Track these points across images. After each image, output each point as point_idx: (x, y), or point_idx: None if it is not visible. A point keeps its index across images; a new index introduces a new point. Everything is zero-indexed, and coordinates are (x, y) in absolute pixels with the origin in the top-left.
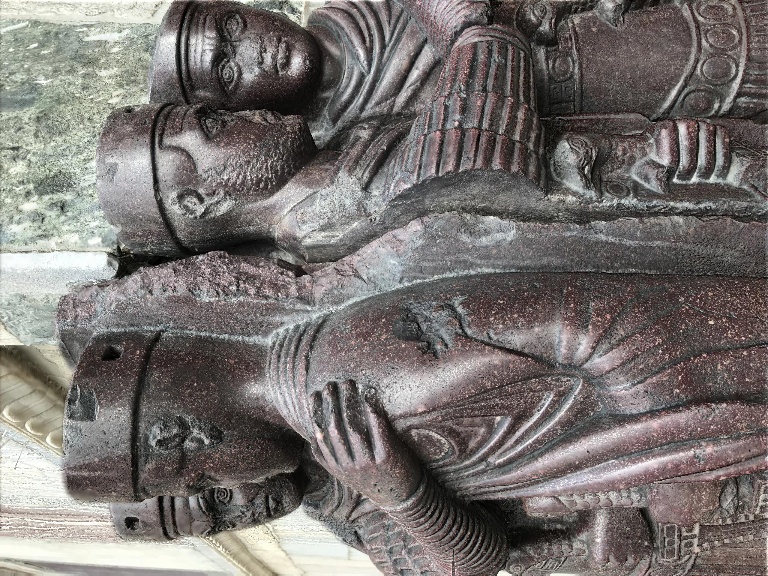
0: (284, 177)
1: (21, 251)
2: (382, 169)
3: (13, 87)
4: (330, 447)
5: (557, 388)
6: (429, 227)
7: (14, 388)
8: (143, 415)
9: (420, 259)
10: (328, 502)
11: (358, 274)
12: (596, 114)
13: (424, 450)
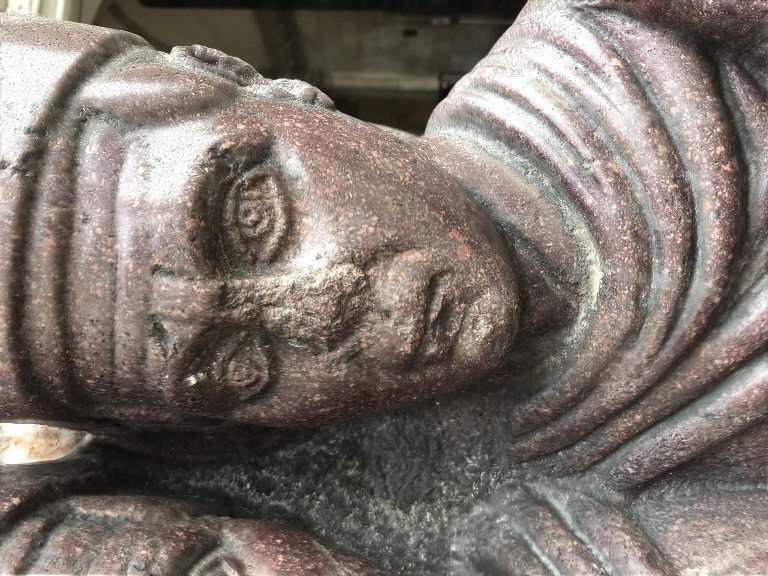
0: None
1: None
2: None
3: None
4: None
5: None
6: None
7: None
8: None
9: None
10: None
11: None
12: None
13: None
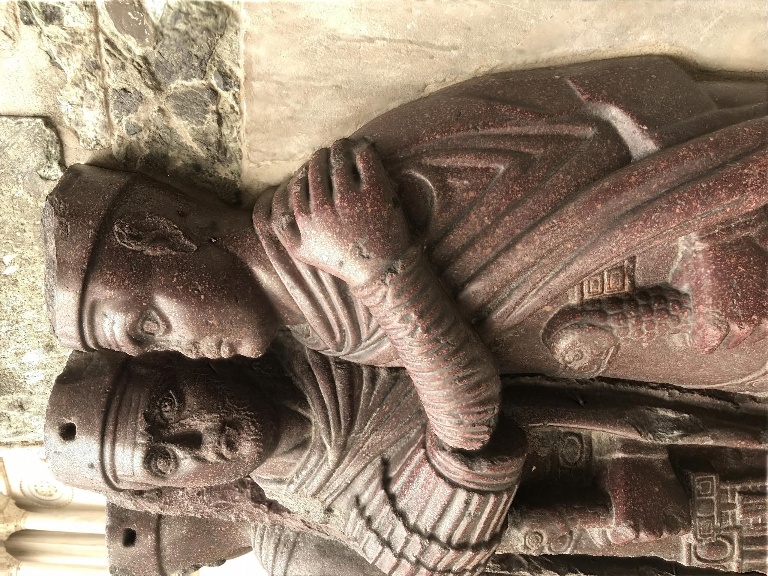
0: None
1: (5, 442)
2: (345, 492)
3: None
4: None
5: None
6: None
7: None
8: (167, 569)
9: None
10: None
11: (322, 530)
12: (593, 426)
13: None
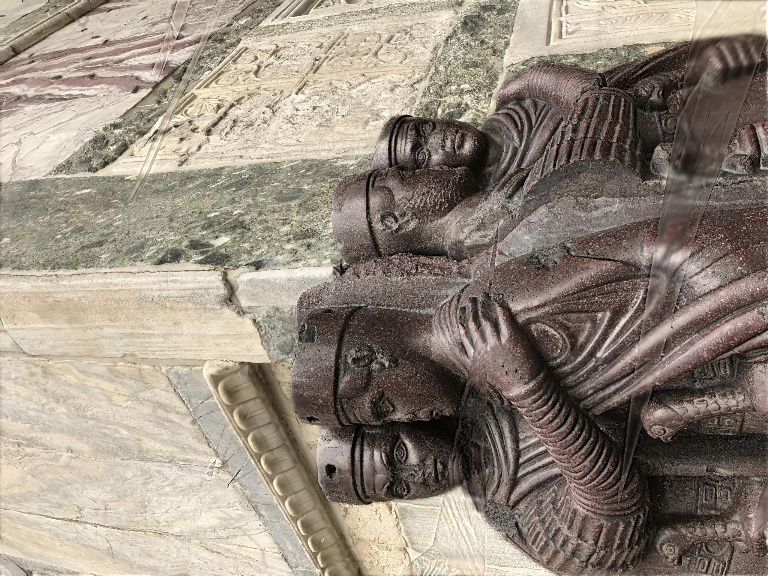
0: (453, 202)
1: None
2: None
3: (288, 191)
4: (470, 339)
5: (645, 287)
6: (552, 208)
7: (258, 414)
8: (345, 342)
9: (546, 232)
10: (490, 484)
11: (502, 252)
12: None
13: (543, 347)
